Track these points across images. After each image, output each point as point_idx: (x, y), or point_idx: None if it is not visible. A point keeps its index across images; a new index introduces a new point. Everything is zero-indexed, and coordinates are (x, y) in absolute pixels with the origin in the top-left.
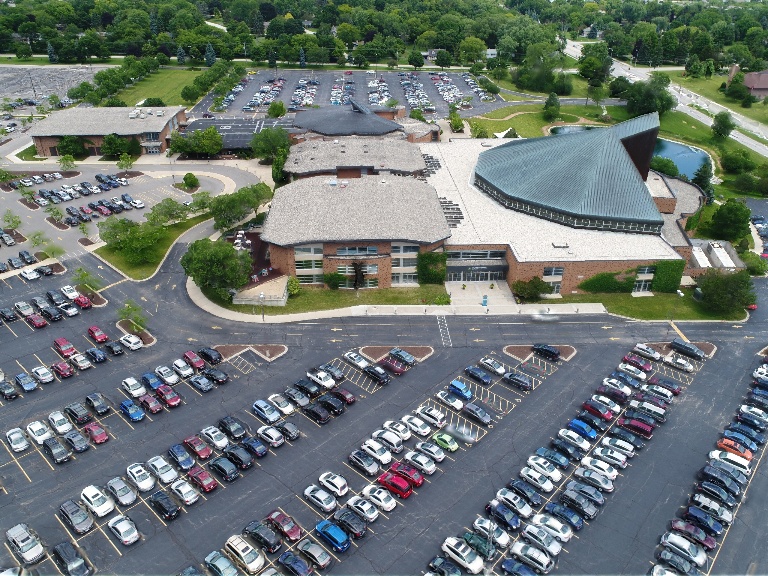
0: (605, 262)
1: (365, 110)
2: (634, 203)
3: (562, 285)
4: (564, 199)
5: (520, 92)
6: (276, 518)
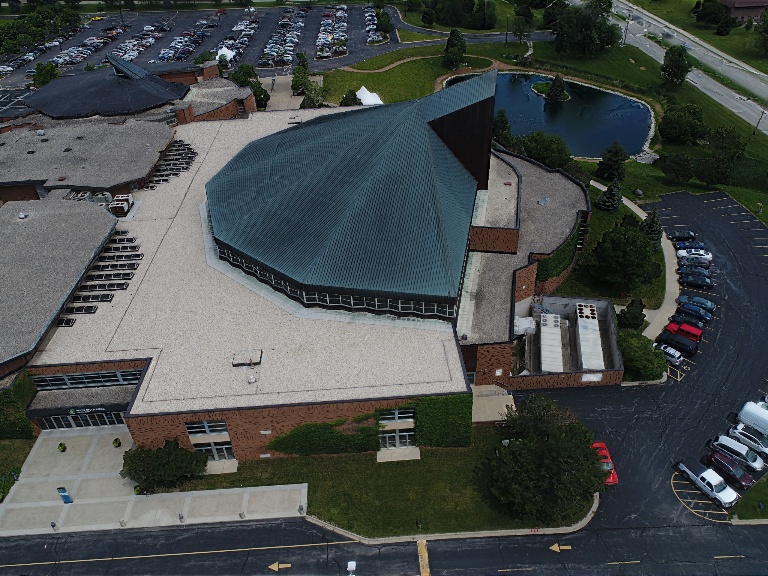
0: (305, 407)
1: (133, 73)
2: (411, 257)
3: (235, 446)
4: (293, 250)
5: (427, 28)
6: None
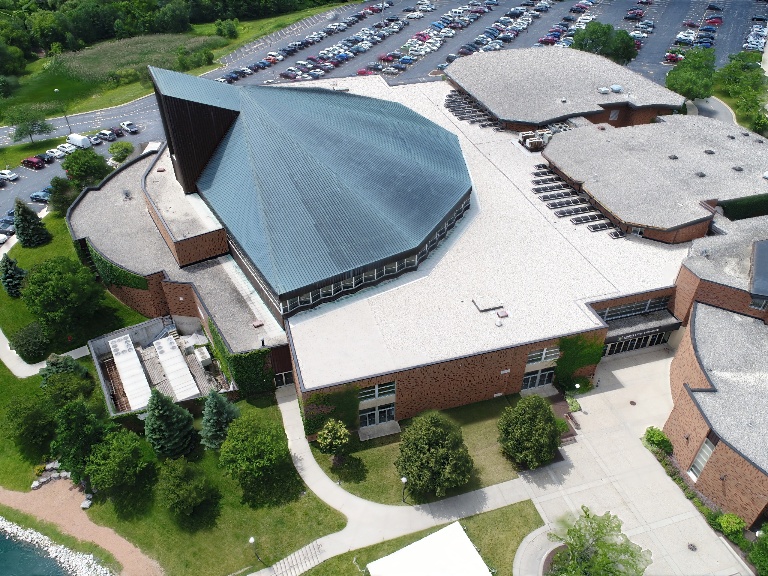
0: None
1: None
2: None
3: None
4: None
5: None
6: (459, 24)
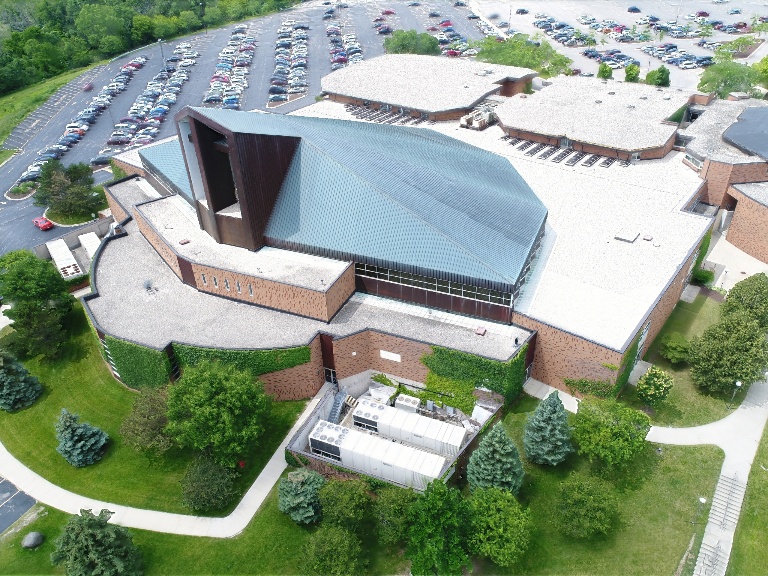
0: None
1: None
2: None
3: None
4: None
5: None
6: None
